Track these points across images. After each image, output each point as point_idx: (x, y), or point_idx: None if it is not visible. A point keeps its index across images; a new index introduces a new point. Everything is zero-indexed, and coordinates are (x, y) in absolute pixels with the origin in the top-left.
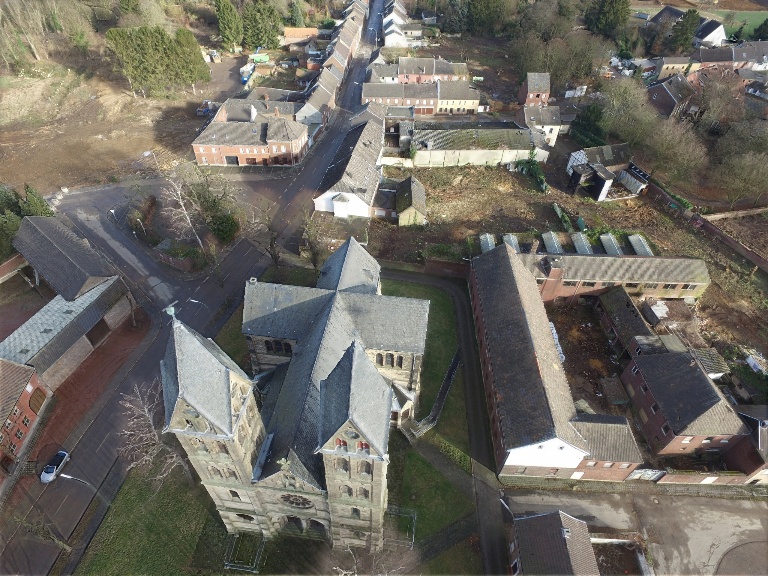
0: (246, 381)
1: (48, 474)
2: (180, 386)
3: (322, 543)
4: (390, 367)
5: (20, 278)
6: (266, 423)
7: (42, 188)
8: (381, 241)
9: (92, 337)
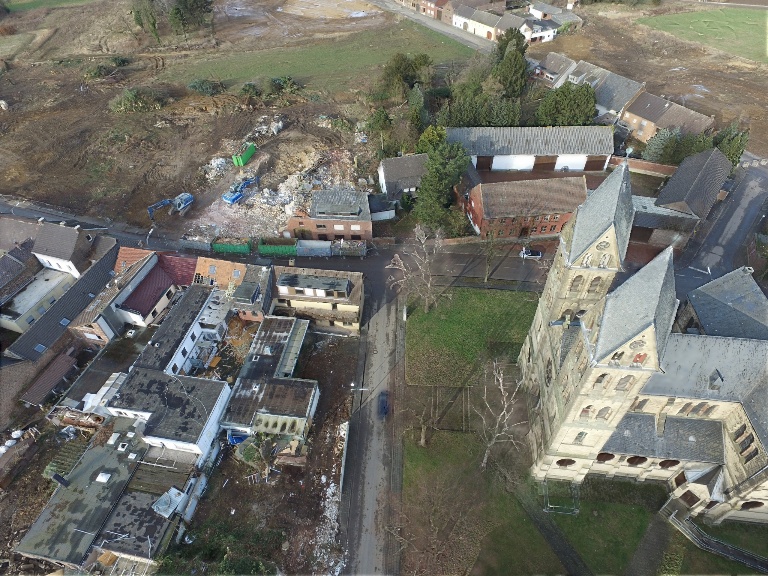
0: (617, 257)
1: (525, 253)
2: (585, 202)
3: (528, 427)
4: (738, 450)
5: (661, 181)
6: None
7: (764, 151)
8: None
9: (633, 233)
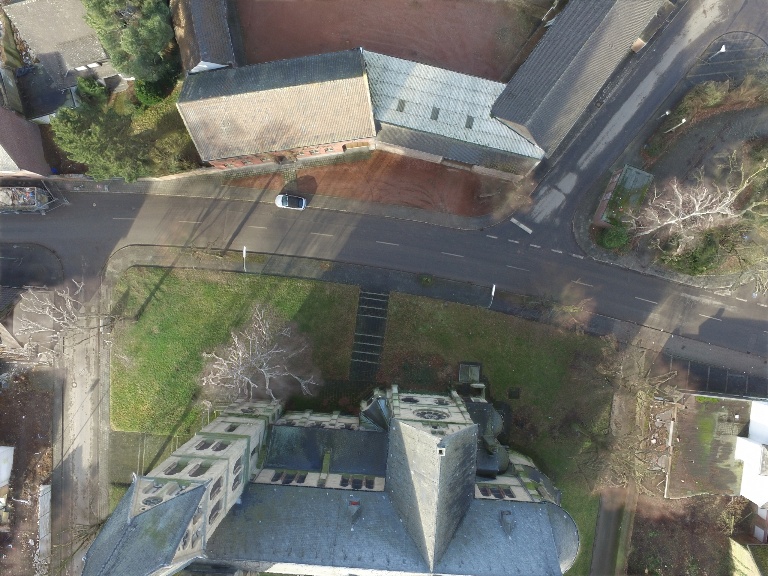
0: None
1: (281, 201)
2: None
3: None
4: None
5: None
6: (308, 442)
7: None
8: (688, 509)
9: None
